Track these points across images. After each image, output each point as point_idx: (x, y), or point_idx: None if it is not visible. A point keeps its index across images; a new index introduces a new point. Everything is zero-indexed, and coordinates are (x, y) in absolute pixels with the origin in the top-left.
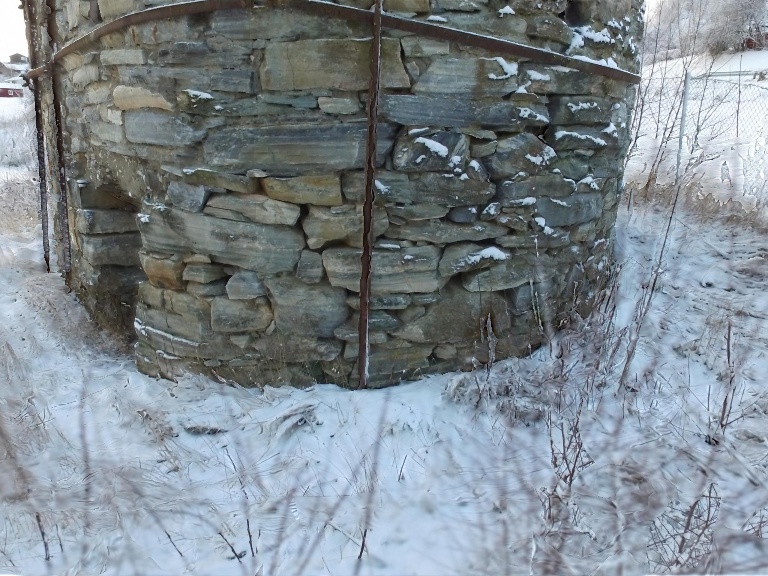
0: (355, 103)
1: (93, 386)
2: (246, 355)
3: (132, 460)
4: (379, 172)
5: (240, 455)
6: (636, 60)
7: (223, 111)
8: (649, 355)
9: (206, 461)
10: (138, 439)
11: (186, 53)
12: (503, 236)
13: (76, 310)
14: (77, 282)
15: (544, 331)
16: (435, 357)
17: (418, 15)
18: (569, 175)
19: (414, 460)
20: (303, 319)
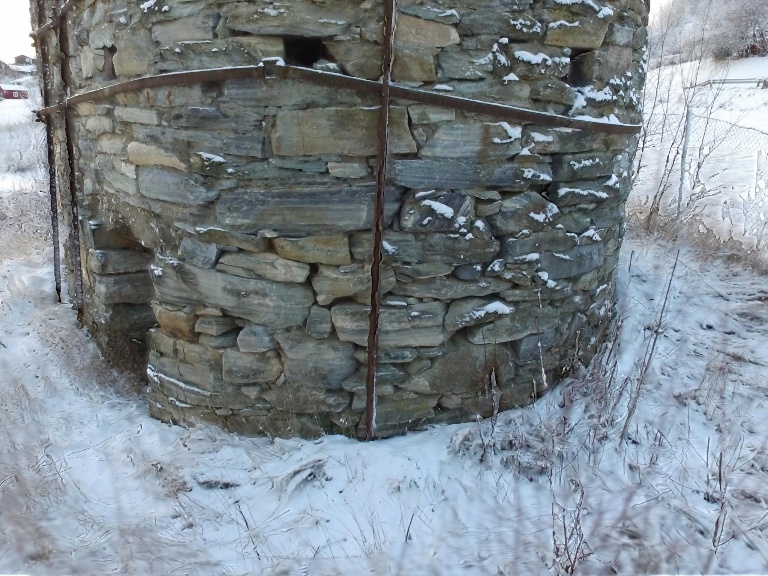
0: (363, 167)
1: (107, 431)
2: (256, 405)
3: (147, 515)
4: (386, 233)
5: (252, 511)
6: (638, 110)
7: (235, 174)
8: (650, 404)
9: (219, 518)
10: (152, 492)
11: (199, 118)
12: (507, 290)
13: (88, 347)
14: (88, 316)
15: (547, 379)
16: (440, 407)
17: (425, 84)
18: (572, 229)
19: (421, 520)
20: (312, 372)
